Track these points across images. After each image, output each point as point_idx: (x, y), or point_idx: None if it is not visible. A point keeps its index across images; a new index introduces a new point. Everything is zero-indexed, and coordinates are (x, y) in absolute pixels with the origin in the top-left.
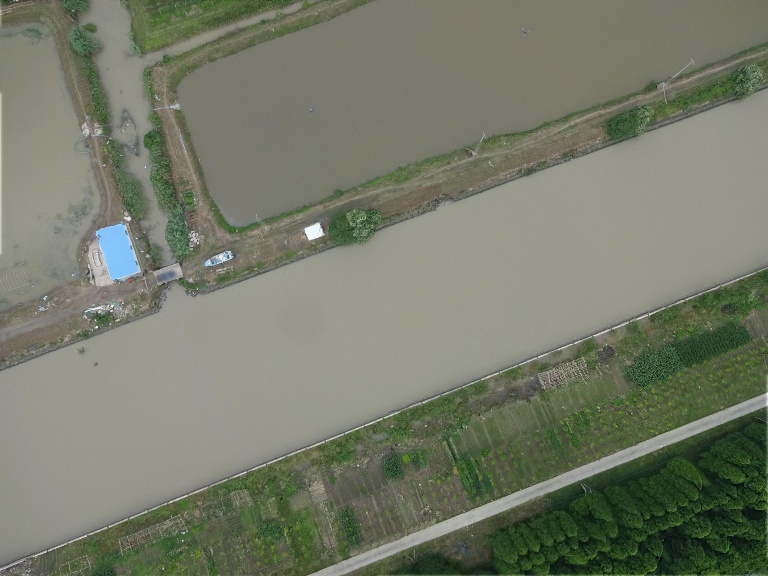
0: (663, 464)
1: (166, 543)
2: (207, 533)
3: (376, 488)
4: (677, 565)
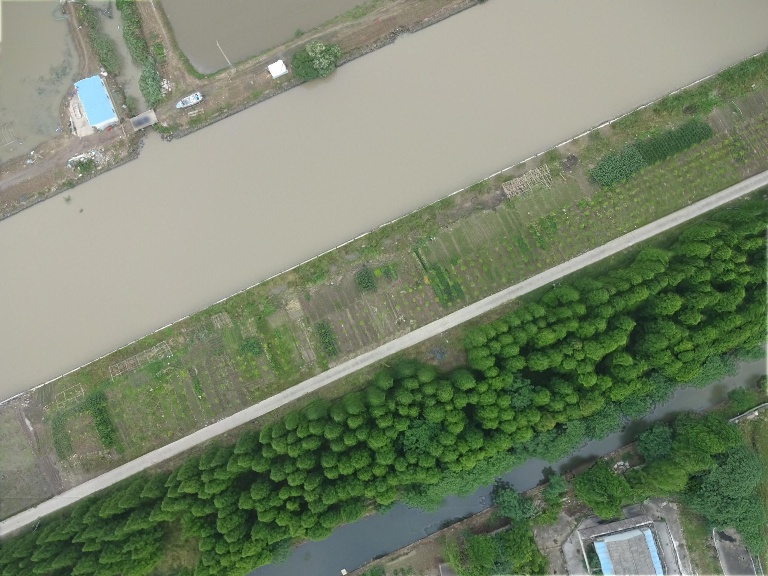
0: (633, 259)
1: (153, 367)
2: (191, 354)
3: (350, 302)
4: (648, 340)
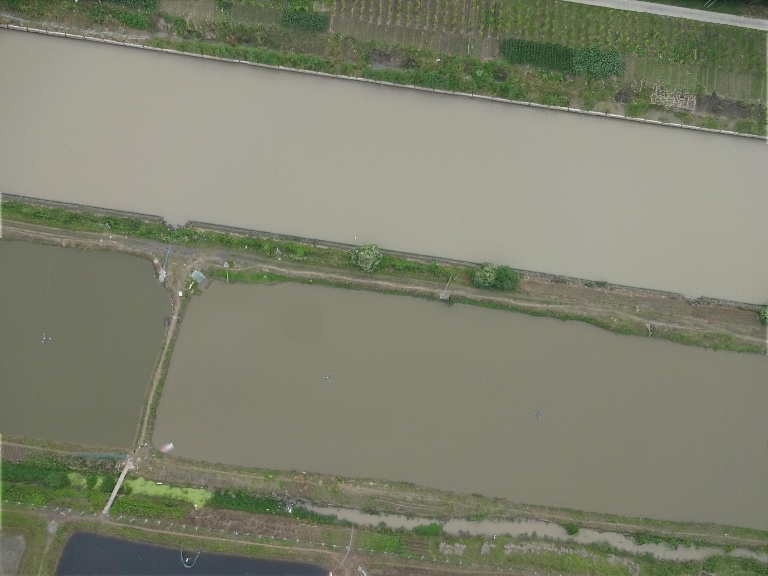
0: None
1: None
2: None
3: None
4: None
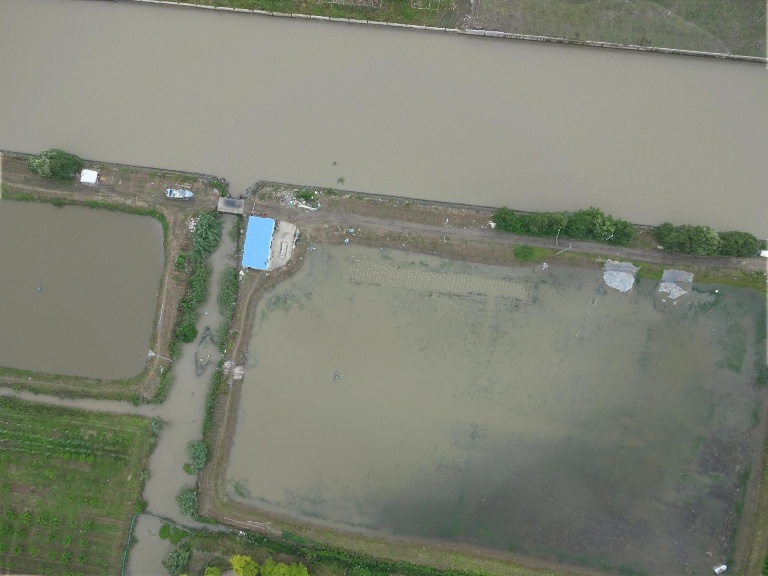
0: None
1: None
2: None
3: None
4: None
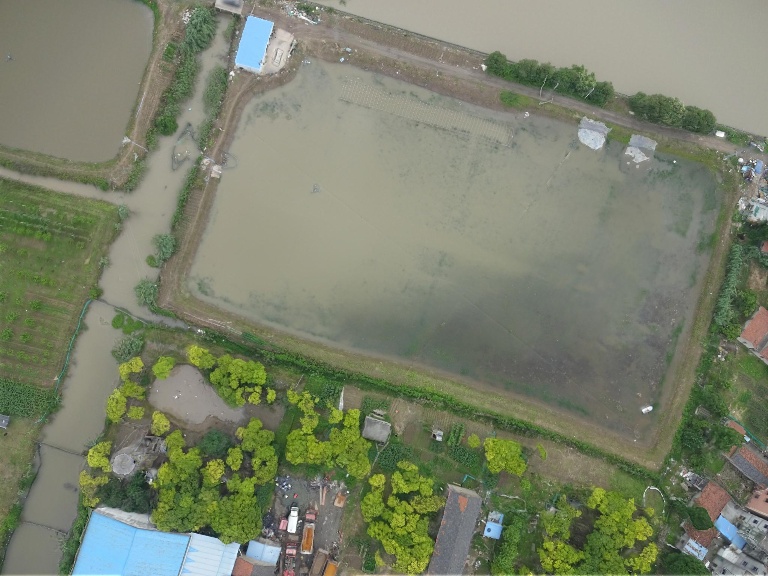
0: None
1: None
2: None
3: None
4: None
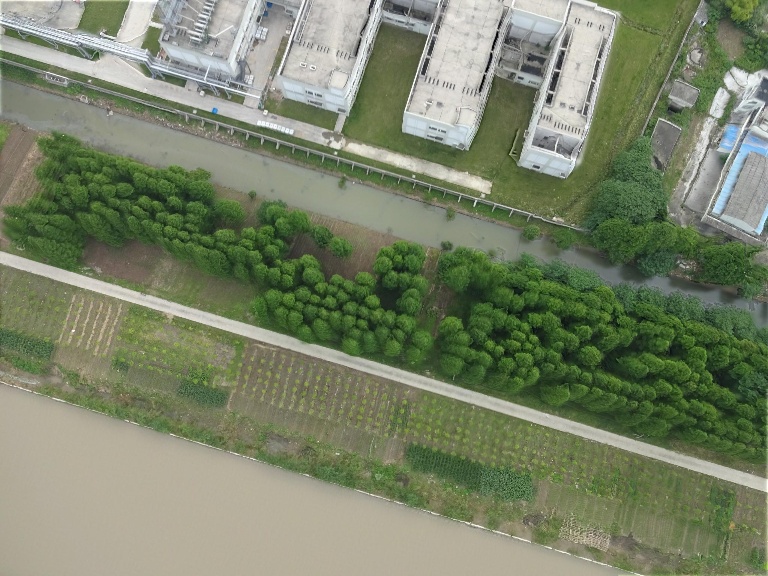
0: None
1: None
2: None
3: None
4: None
